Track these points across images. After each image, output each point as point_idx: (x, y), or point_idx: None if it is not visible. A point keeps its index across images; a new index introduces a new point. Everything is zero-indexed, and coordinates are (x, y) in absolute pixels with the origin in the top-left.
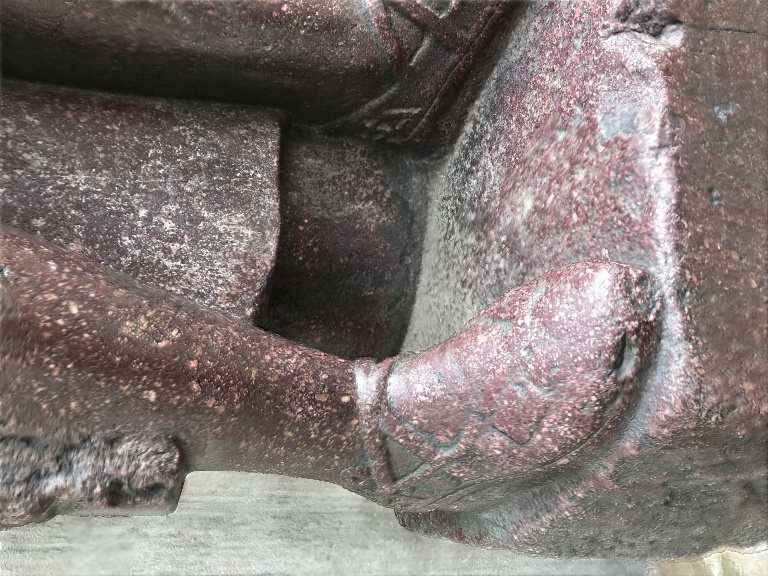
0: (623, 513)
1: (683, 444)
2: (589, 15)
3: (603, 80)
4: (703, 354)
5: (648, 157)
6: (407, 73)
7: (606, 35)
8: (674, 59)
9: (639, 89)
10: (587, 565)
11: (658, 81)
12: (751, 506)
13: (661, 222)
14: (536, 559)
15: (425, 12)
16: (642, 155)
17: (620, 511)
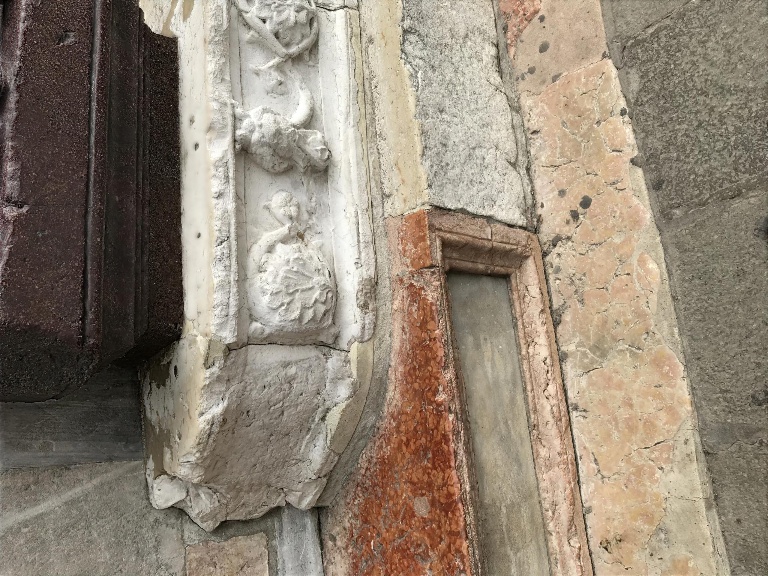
0: (6, 363)
1: (1, 333)
2: (2, 199)
3: (2, 221)
4: (4, 306)
5: (4, 248)
6: None
7: (4, 207)
8: (20, 217)
9: (8, 226)
10: (102, 435)
11: (12, 224)
12: (57, 362)
13: (0, 268)
14: (69, 430)
15: None
16: (2, 247)
17: (3, 362)
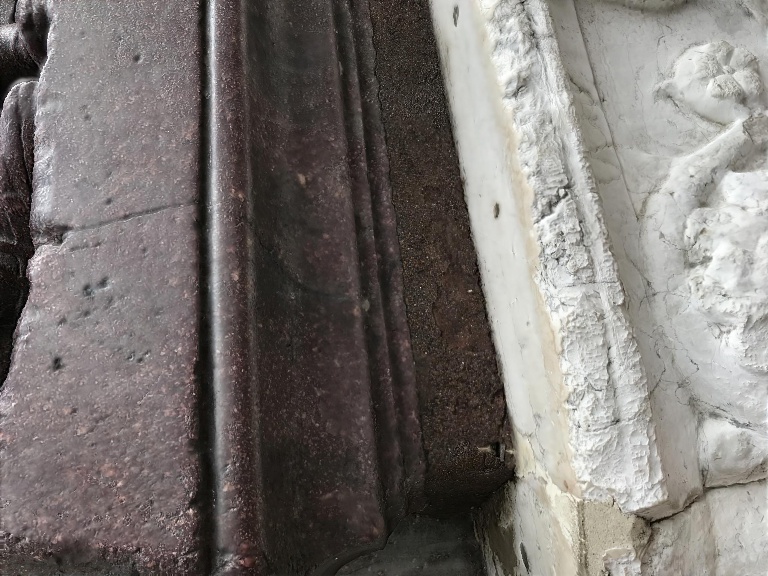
0: None
1: None
2: None
3: None
4: None
5: None
6: (22, 283)
7: None
8: (44, 265)
9: None
10: None
11: None
12: None
13: None
14: None
15: (3, 244)
16: None
17: None
